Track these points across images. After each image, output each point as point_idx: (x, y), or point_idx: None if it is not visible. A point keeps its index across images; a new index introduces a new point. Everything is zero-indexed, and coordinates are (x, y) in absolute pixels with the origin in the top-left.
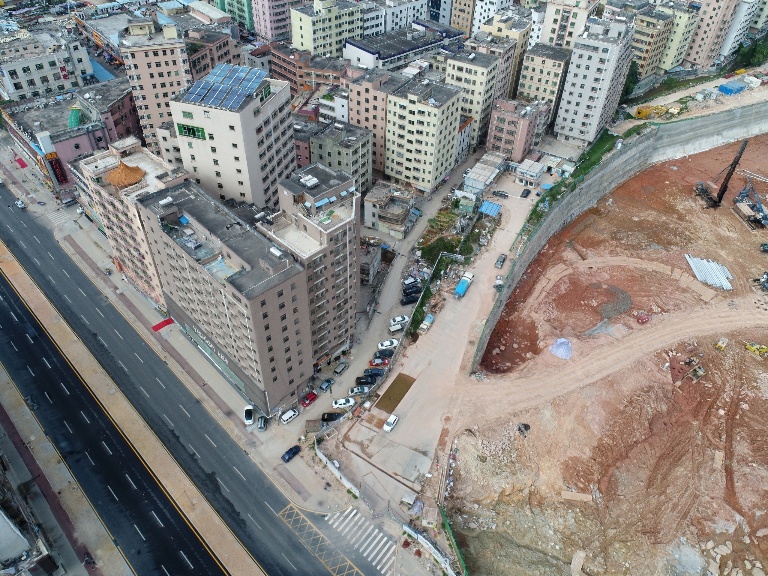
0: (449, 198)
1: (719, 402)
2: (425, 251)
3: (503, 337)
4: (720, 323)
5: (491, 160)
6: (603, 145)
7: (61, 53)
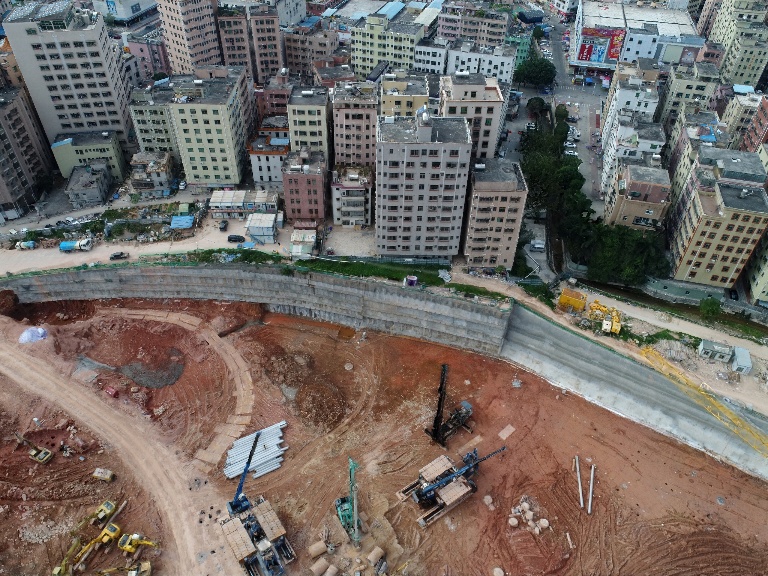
0: (199, 201)
1: (2, 483)
2: (105, 211)
3: (81, 315)
4: (153, 473)
5: (257, 196)
6: (397, 270)
7: (258, 3)
